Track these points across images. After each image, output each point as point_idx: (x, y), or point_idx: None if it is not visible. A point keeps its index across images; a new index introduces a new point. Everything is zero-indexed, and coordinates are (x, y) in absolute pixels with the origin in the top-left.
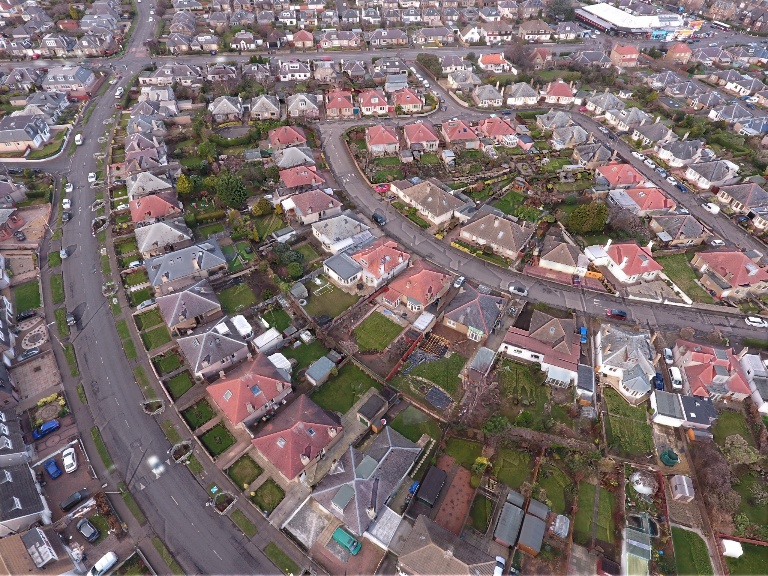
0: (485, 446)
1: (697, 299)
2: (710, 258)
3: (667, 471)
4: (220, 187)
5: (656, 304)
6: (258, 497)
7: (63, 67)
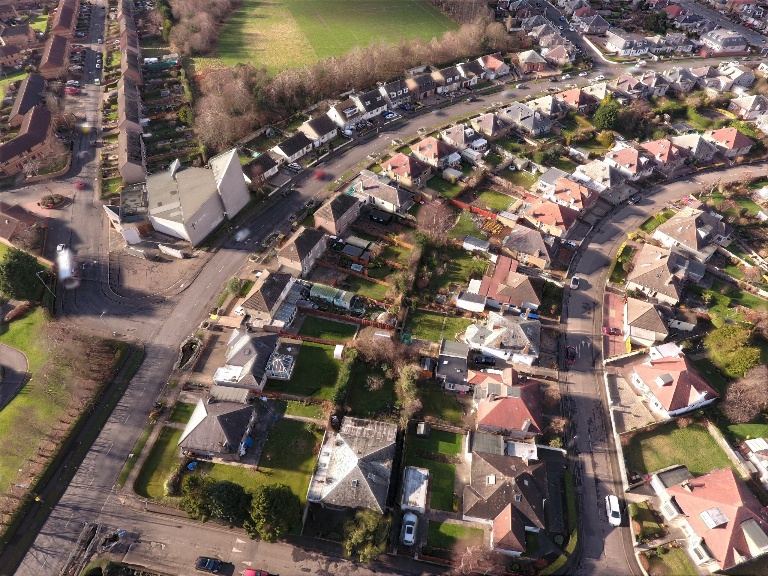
0: (405, 234)
1: (626, 439)
2: (722, 477)
3: (397, 339)
4: (601, 106)
5: (605, 401)
6: (376, 165)
7: (730, 31)
